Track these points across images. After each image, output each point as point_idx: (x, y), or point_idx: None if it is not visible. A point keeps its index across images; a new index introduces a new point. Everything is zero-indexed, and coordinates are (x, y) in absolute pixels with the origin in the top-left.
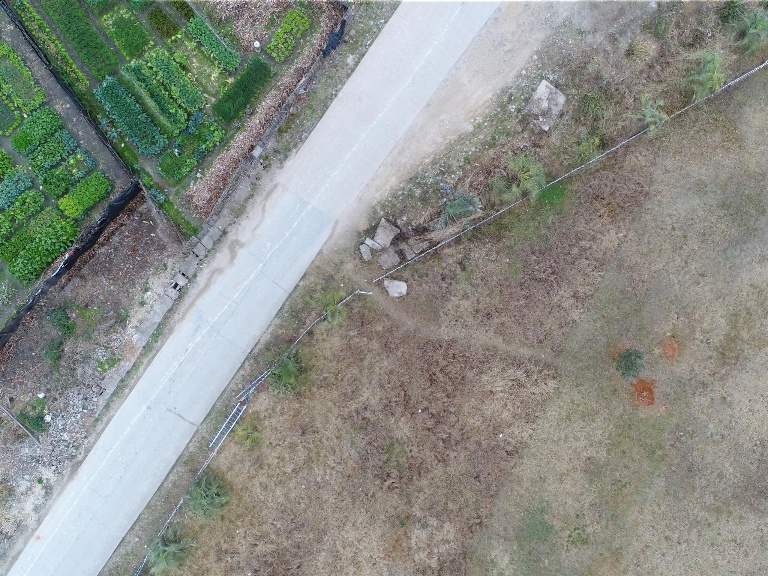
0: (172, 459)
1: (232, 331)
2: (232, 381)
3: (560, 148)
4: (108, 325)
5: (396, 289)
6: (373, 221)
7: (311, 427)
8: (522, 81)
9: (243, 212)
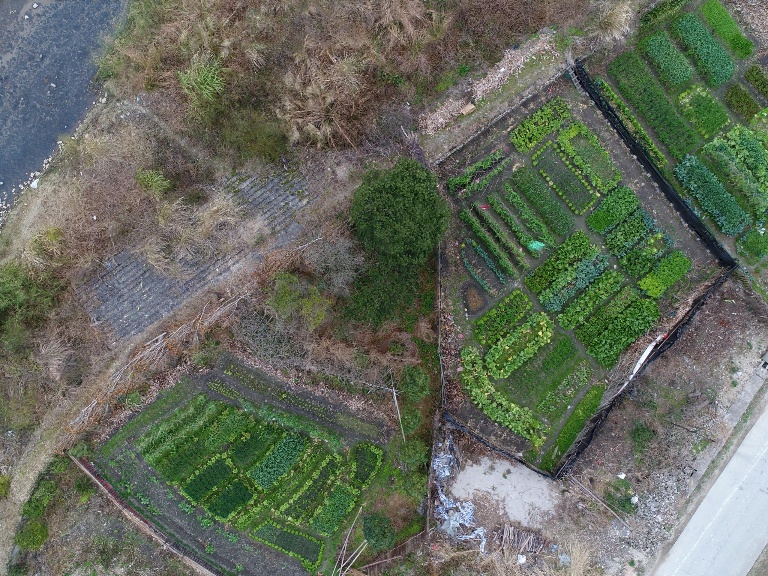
0: (765, 540)
1: None
2: None
3: None
4: (703, 406)
5: None
6: None
7: None
8: None
9: None
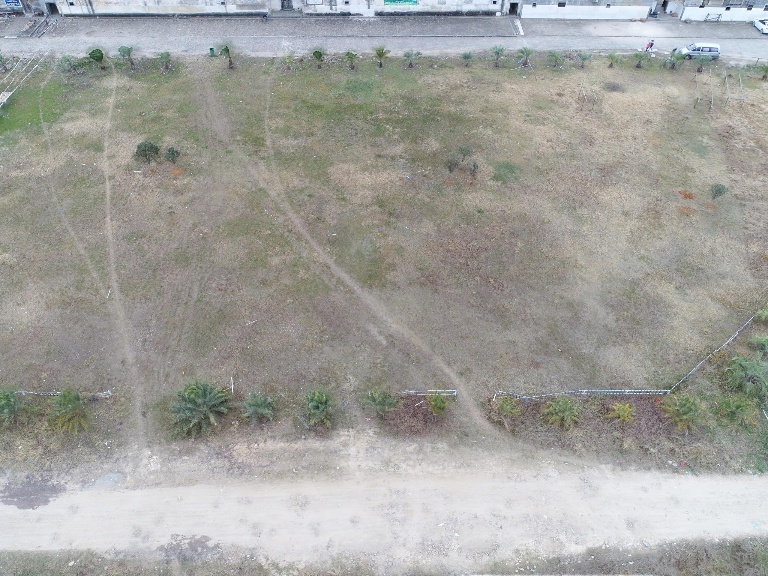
0: None
1: None
2: None
3: None
4: None
5: None
6: None
7: None
8: None
9: None
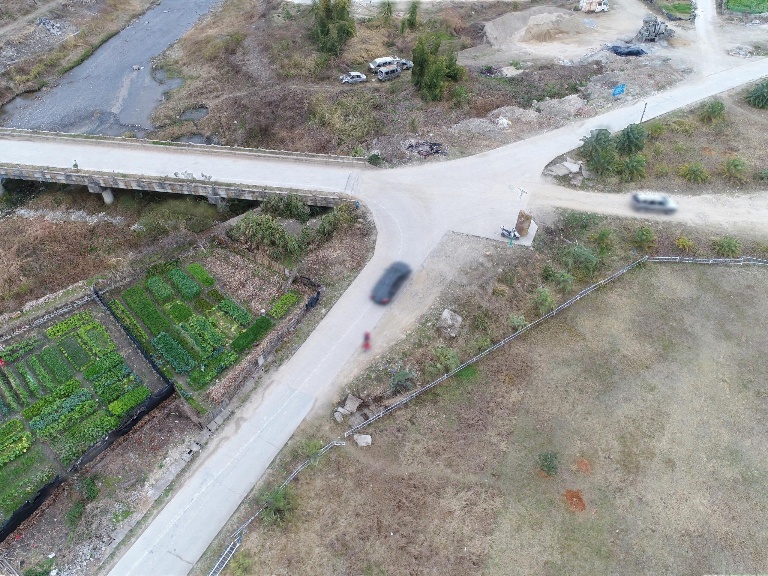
0: None
1: (232, 481)
2: (228, 522)
3: (466, 348)
4: (129, 484)
5: (363, 440)
6: (343, 397)
7: (296, 557)
8: (432, 311)
9: (248, 399)
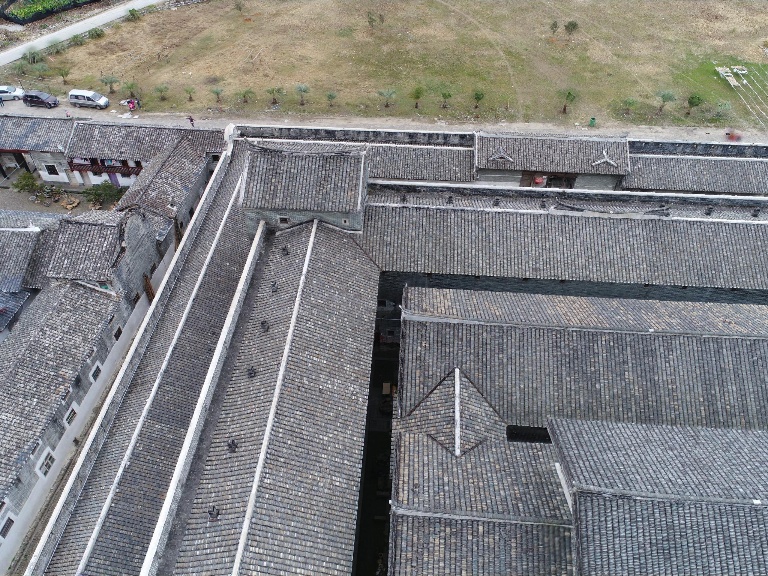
0: None
1: None
2: (115, 20)
3: None
4: (80, 12)
5: None
6: None
7: None
8: None
9: (131, 0)
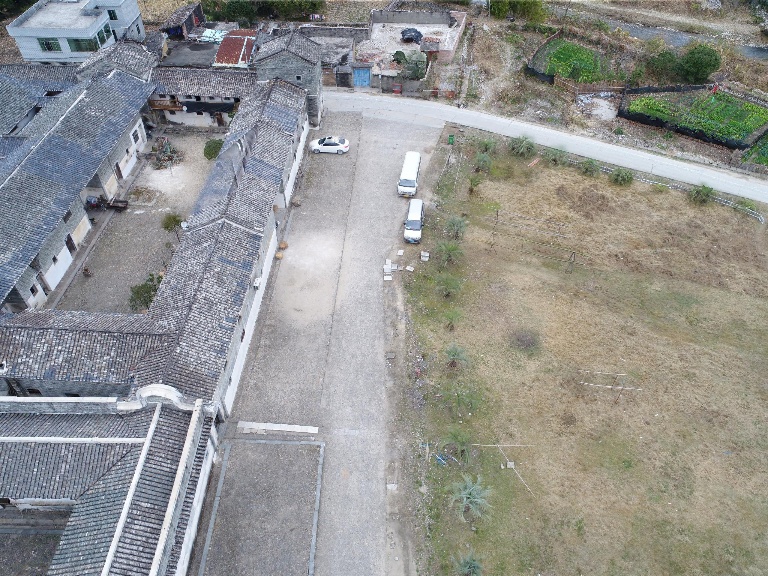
0: (631, 167)
1: (705, 180)
2: (680, 182)
3: None
4: (679, 145)
5: None
6: None
7: (677, 209)
8: None
9: (763, 179)
